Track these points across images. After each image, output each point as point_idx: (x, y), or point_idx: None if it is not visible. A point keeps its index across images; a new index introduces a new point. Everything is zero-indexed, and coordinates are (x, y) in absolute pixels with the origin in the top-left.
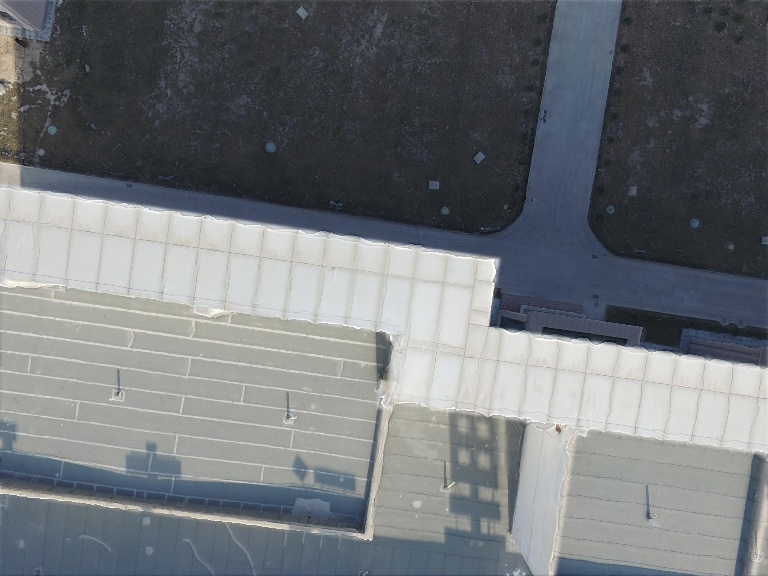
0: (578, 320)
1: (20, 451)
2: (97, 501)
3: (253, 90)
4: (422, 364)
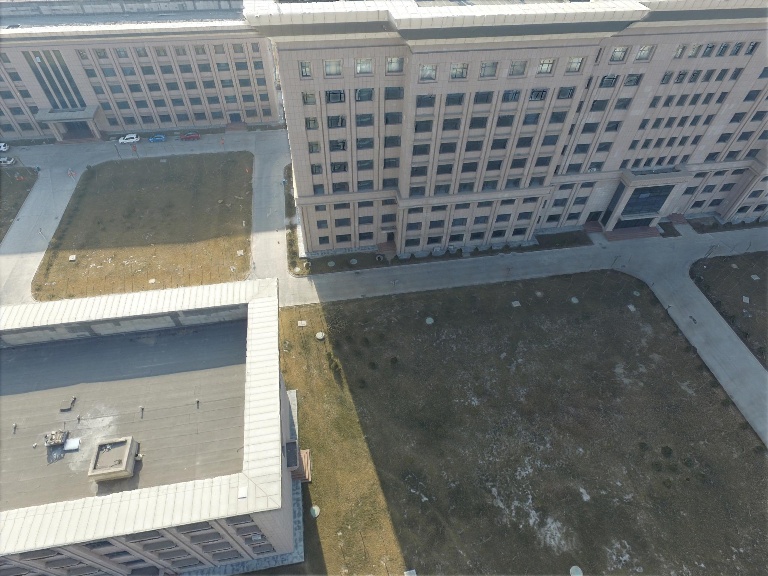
0: (668, 177)
1: None
2: None
3: None
4: None
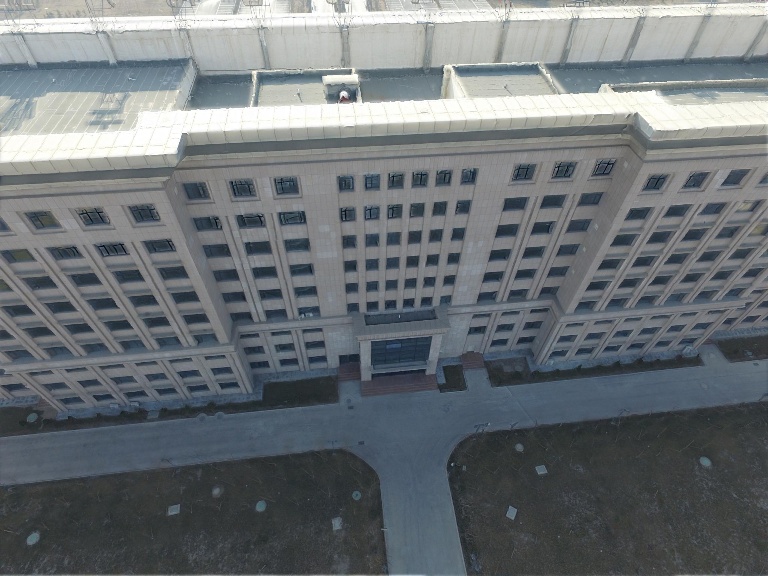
0: (411, 329)
1: (761, 93)
2: (719, 81)
3: (764, 517)
4: (654, 100)
